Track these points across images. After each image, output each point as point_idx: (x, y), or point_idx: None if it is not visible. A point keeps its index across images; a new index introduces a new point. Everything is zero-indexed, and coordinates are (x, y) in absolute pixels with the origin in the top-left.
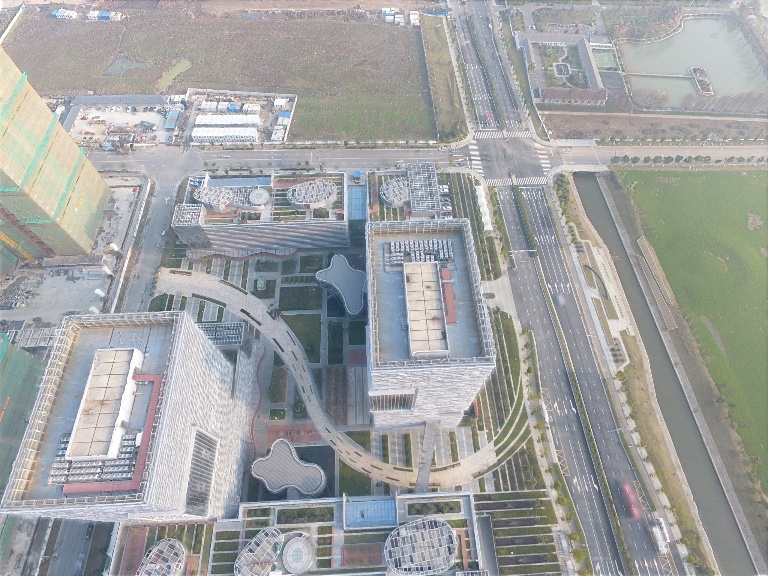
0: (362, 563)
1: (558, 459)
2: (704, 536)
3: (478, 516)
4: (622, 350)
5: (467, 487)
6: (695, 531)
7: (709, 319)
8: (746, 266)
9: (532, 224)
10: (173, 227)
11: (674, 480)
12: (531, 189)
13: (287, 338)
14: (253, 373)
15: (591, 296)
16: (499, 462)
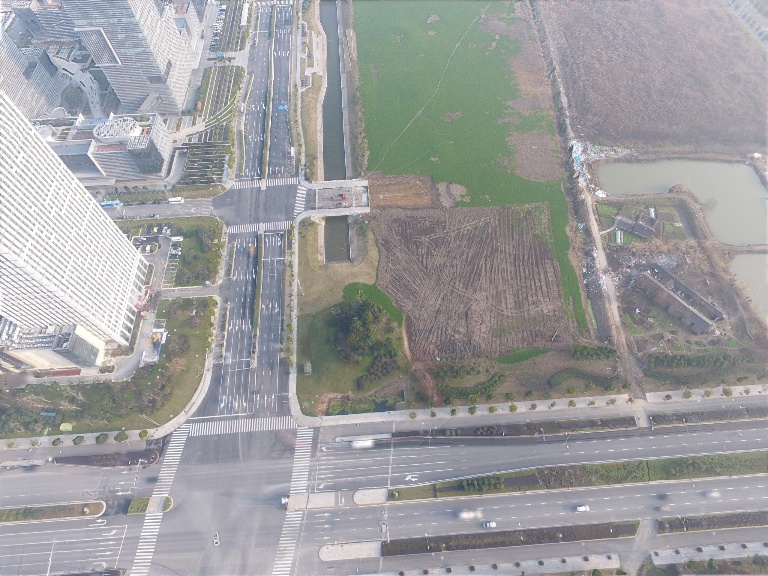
0: (81, 138)
1: (244, 128)
2: (320, 159)
3: (181, 151)
4: (309, 81)
5: (180, 140)
6: (315, 156)
7: (374, 65)
8: (412, 39)
9: (277, 23)
10: (13, 9)
11: (312, 135)
12: (285, 6)
13: (89, 80)
14: (59, 92)
15: (301, 57)
16: (205, 130)
